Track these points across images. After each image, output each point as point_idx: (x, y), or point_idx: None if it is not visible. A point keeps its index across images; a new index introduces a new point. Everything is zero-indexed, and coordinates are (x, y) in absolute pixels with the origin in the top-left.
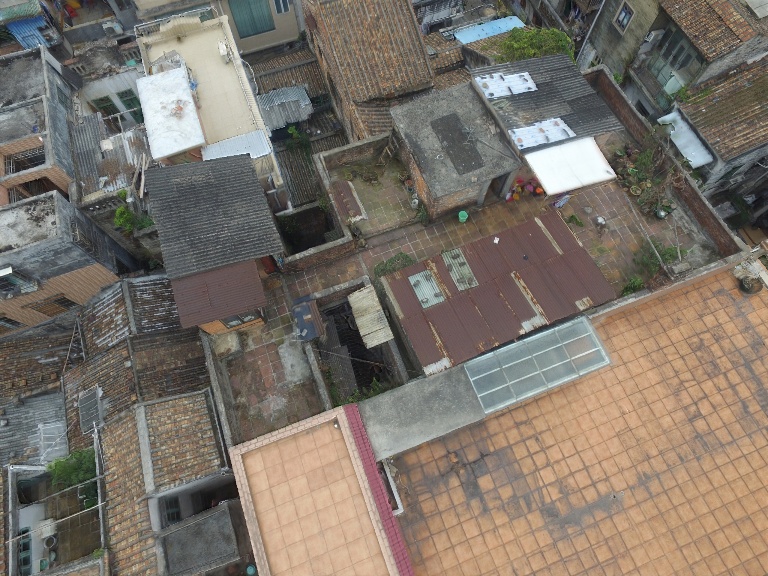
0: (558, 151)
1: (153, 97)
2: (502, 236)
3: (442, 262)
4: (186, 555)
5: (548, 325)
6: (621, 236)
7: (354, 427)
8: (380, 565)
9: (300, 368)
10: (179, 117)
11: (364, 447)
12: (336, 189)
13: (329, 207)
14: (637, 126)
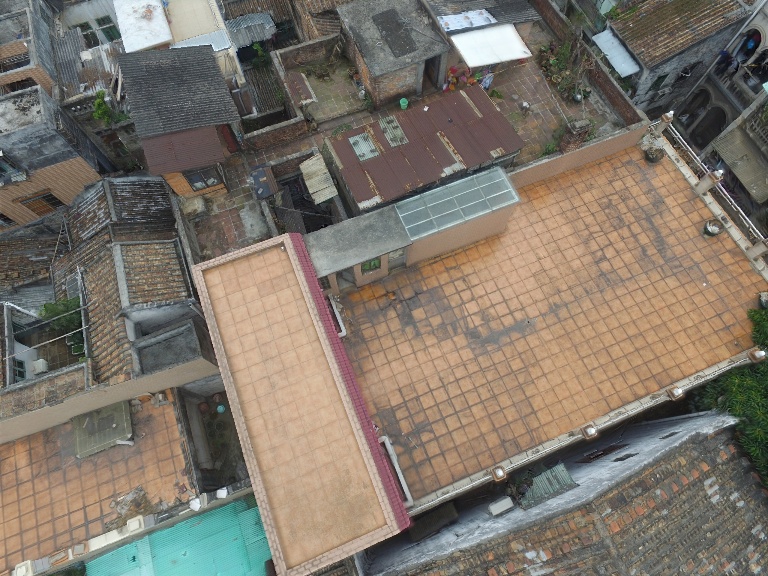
0: (481, 34)
1: (126, 3)
2: (431, 105)
3: (378, 126)
4: (158, 364)
5: (468, 174)
6: (543, 117)
7: (298, 249)
8: (317, 348)
9: (259, 227)
10: (149, 19)
11: (306, 264)
12: (290, 79)
13: (285, 96)
14: (560, 25)
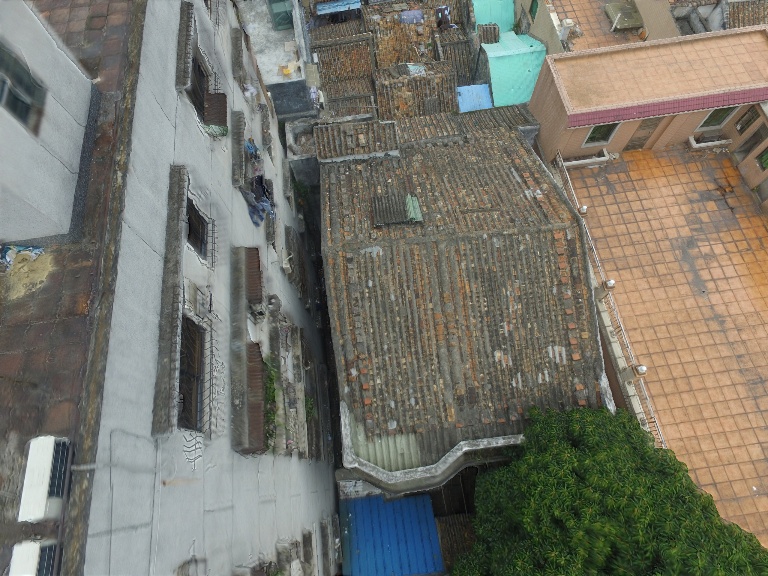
0: None
1: None
2: None
3: None
4: None
5: None
6: None
7: None
8: None
9: None
10: None
11: None
12: None
13: None
14: None
